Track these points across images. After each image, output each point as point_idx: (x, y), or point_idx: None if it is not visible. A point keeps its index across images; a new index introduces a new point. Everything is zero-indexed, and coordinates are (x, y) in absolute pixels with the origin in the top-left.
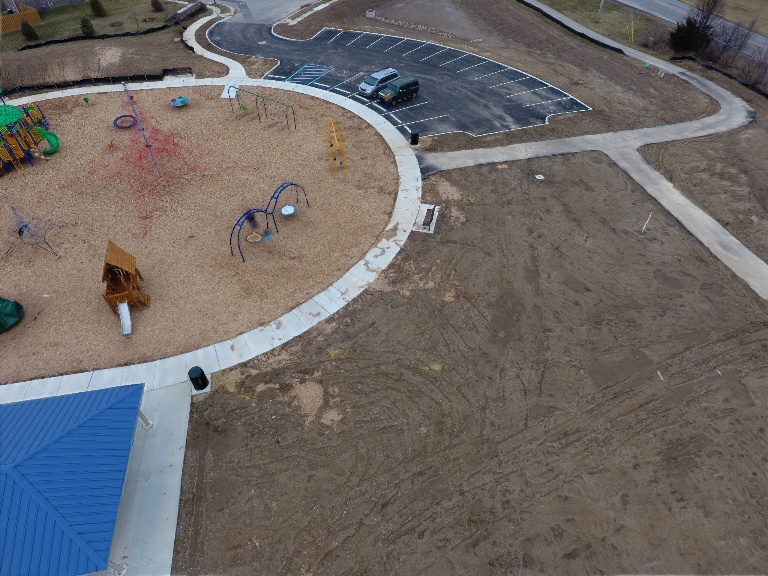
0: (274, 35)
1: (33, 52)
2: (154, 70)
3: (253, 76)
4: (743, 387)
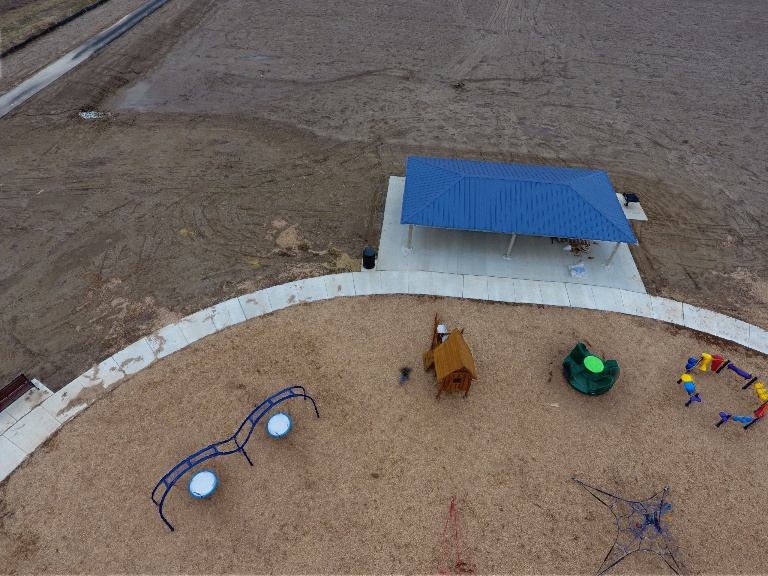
0: None
1: None
2: None
3: None
4: (3, 176)
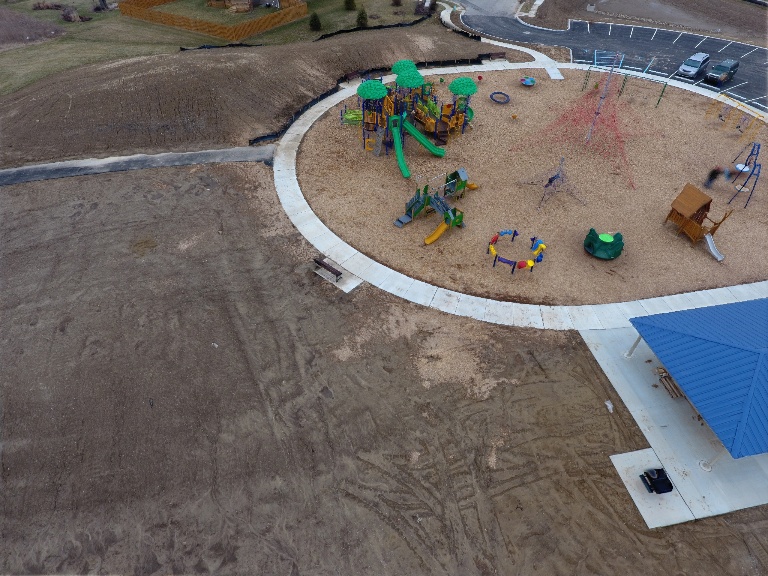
0: (529, 26)
1: (359, 39)
2: (468, 55)
3: (560, 60)
4: None
